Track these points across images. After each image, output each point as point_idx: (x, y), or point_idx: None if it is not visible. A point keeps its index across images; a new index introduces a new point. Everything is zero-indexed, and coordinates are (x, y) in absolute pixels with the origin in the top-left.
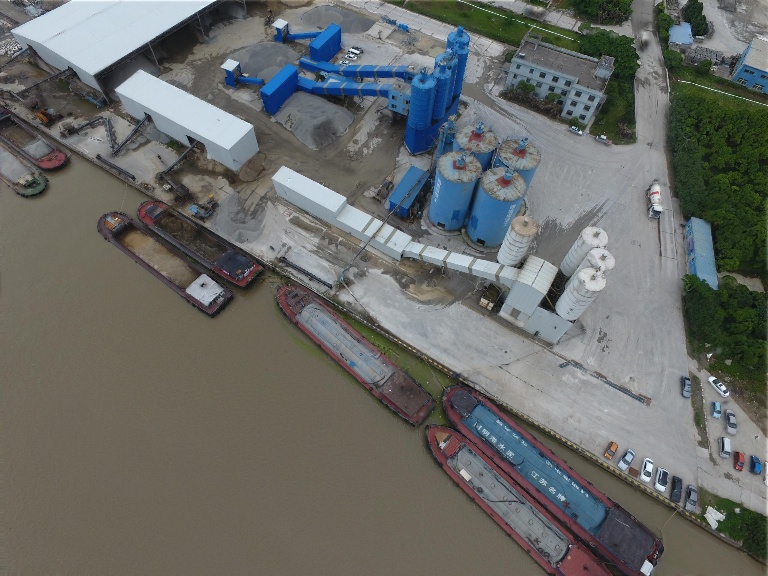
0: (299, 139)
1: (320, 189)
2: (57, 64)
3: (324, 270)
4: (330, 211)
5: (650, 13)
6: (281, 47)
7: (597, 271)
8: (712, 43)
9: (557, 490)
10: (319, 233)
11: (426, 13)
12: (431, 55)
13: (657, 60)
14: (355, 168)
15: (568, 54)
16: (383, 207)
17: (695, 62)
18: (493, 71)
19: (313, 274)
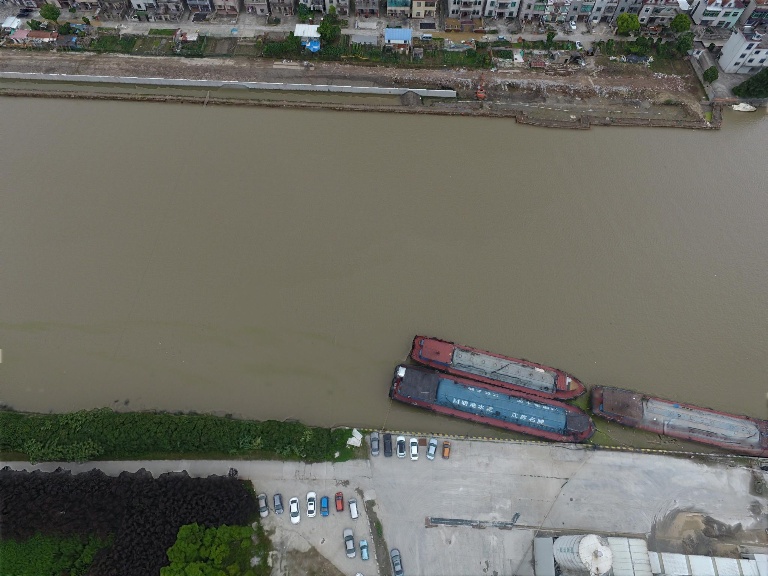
0: None
1: None
2: None
3: None
4: None
5: None
6: None
7: (598, 569)
8: None
9: (477, 392)
10: None
11: None
12: None
13: None
14: None
15: None
16: None
17: None
18: None
19: None
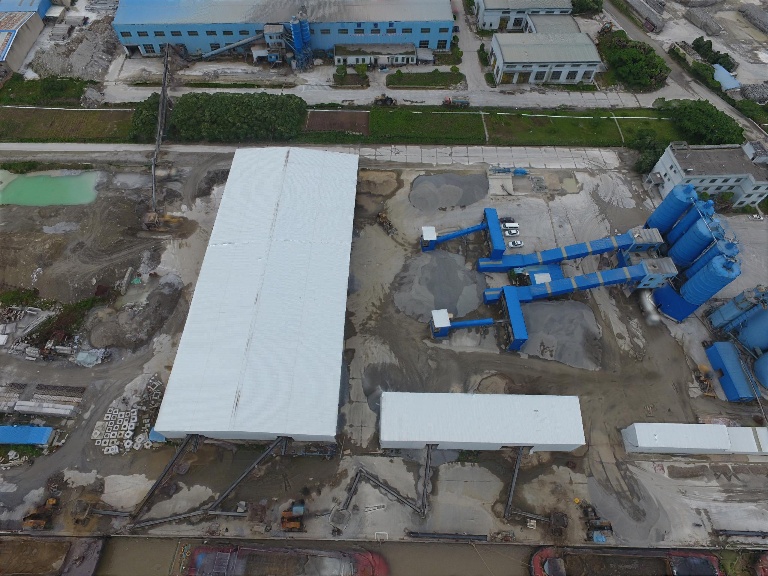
0: (572, 366)
1: (694, 430)
2: (248, 437)
3: (759, 516)
4: (724, 449)
5: (672, 62)
6: (446, 259)
7: None
8: (741, 74)
9: None
10: (708, 473)
11: (517, 143)
12: (570, 192)
13: (731, 111)
14: (652, 369)
15: (711, 149)
16: (720, 401)
17: (755, 101)
18: (634, 184)
19: (757, 528)
